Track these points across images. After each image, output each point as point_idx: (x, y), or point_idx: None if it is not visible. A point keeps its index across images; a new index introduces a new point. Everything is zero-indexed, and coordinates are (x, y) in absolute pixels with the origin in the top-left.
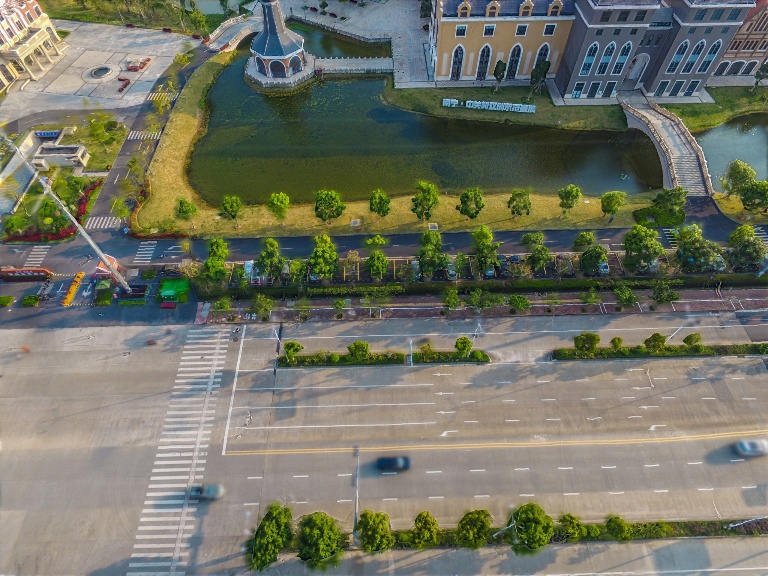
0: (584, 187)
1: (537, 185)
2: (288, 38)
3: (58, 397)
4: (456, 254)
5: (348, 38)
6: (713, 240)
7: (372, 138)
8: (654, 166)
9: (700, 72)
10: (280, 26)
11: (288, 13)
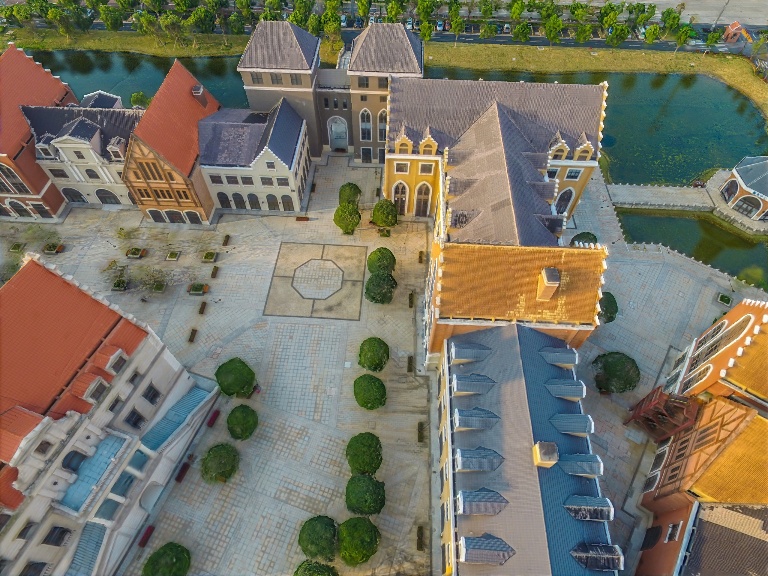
0: (426, 71)
1: (461, 75)
2: None
3: (706, 5)
4: None
5: None
6: None
7: None
8: None
9: None
10: None
11: None
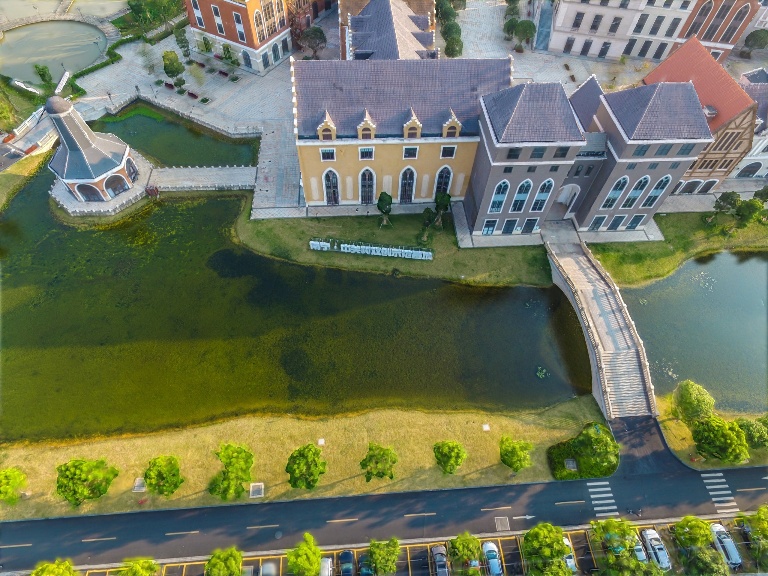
0: (486, 393)
1: (422, 391)
2: (99, 153)
3: None
4: (282, 547)
5: (207, 130)
6: (655, 503)
7: (206, 305)
8: (582, 354)
9: (645, 207)
10: (83, 140)
11: (134, 91)
